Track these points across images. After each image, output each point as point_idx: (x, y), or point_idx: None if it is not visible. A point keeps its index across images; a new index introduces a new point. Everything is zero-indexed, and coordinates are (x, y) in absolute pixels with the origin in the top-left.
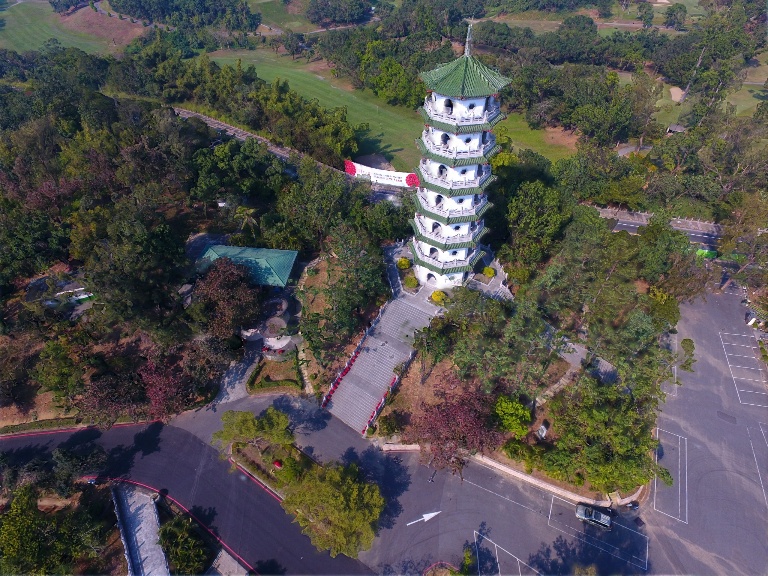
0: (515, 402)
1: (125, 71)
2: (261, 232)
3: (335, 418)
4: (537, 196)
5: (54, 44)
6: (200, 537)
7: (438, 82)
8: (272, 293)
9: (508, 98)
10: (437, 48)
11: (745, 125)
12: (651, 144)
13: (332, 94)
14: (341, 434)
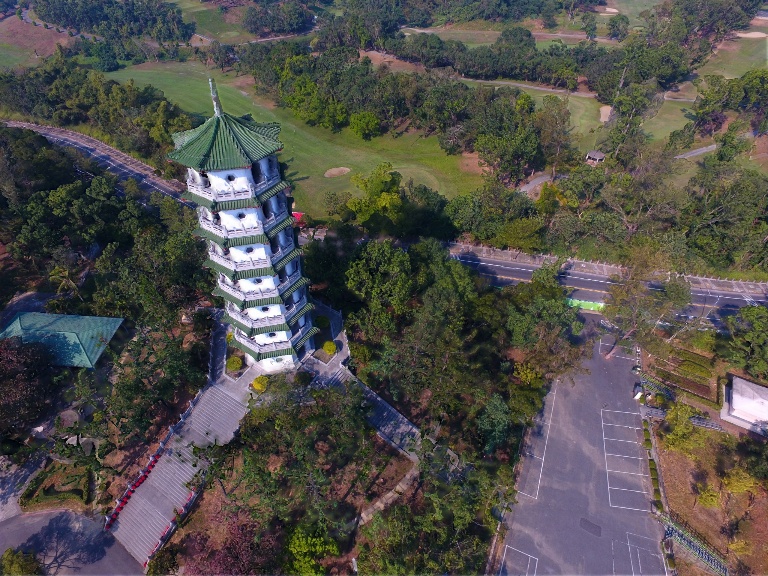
0: (310, 537)
1: (13, 91)
2: (97, 291)
3: (118, 544)
4: (383, 259)
5: None
6: None
7: (182, 149)
8: (85, 372)
9: (422, 121)
10: (354, 65)
11: (653, 158)
12: (568, 172)
13: (251, 112)
14: (119, 567)
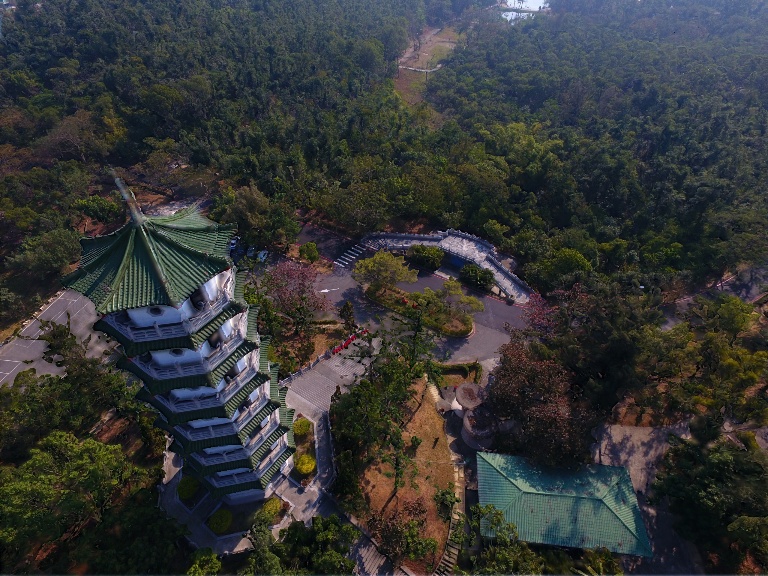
0: None
1: None
2: None
3: None
4: None
5: None
6: (471, 285)
7: None
8: None
9: None
10: None
11: None
12: None
13: None
14: None
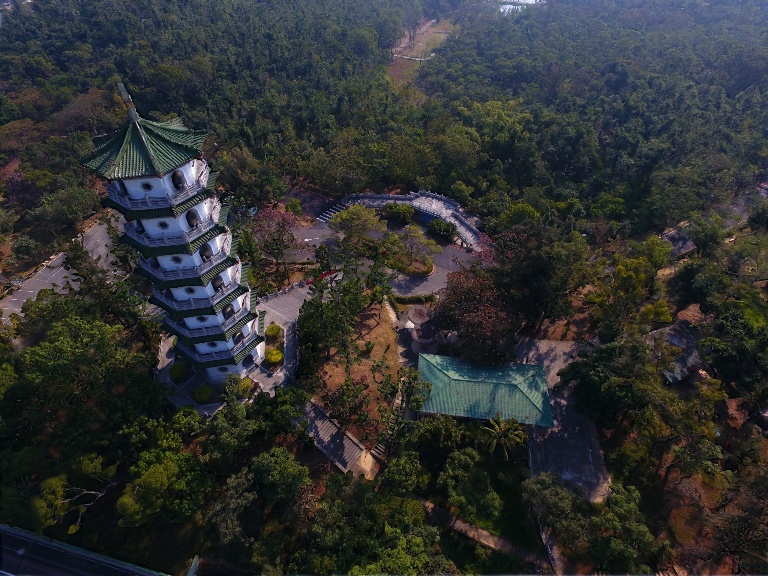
0: None
1: None
2: None
3: None
4: None
5: None
6: (436, 237)
7: None
8: None
9: None
10: None
11: None
12: None
13: None
14: None
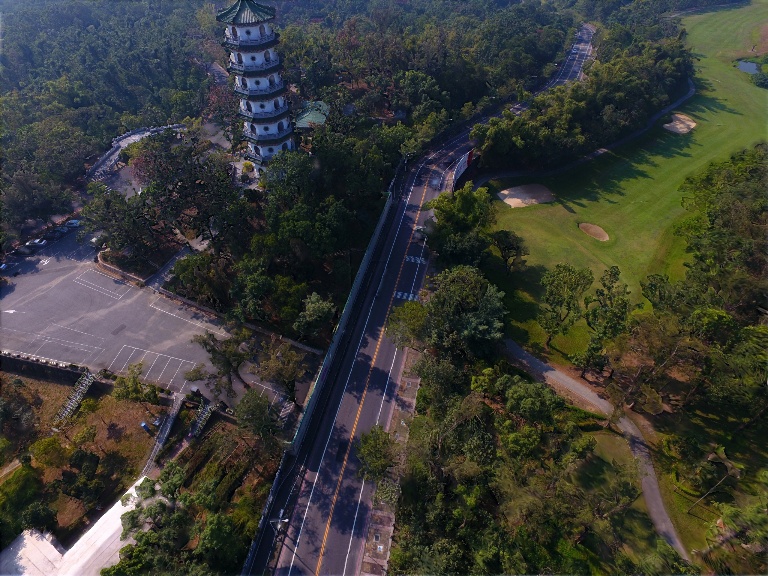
0: None
1: None
2: None
3: None
4: None
5: (677, 24)
6: None
7: None
8: None
9: None
10: None
11: None
12: (661, 468)
13: None
14: None
